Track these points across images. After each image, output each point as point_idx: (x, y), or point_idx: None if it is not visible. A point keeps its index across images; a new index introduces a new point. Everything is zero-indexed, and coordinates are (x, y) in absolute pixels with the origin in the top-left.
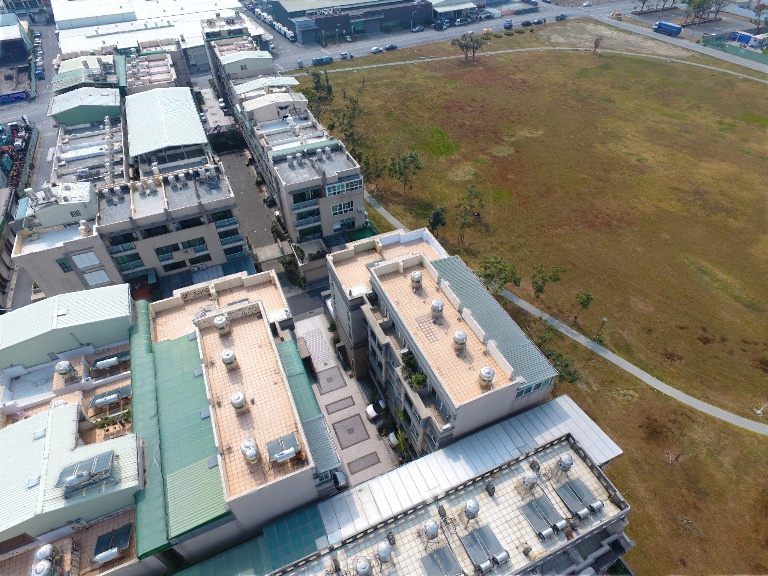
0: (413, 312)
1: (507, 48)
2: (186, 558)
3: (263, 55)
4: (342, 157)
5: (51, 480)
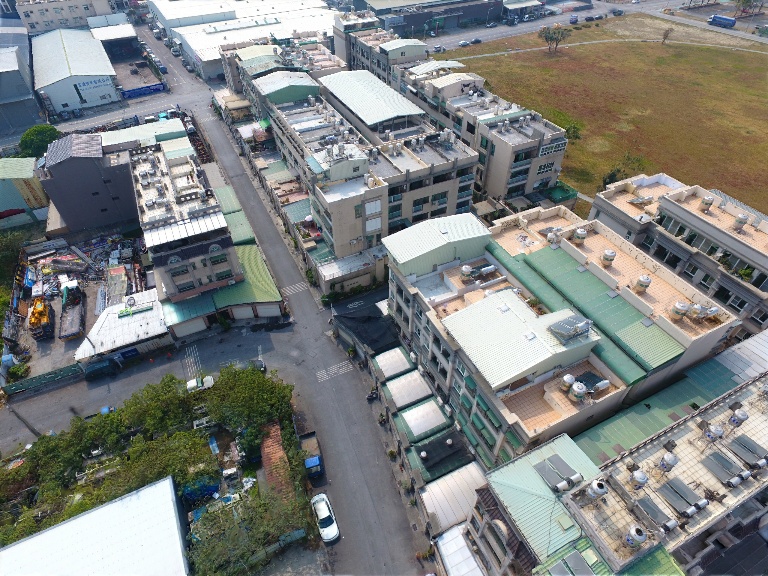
0: None
1: (581, 40)
2: (632, 396)
3: (418, 43)
4: (538, 125)
5: (542, 335)
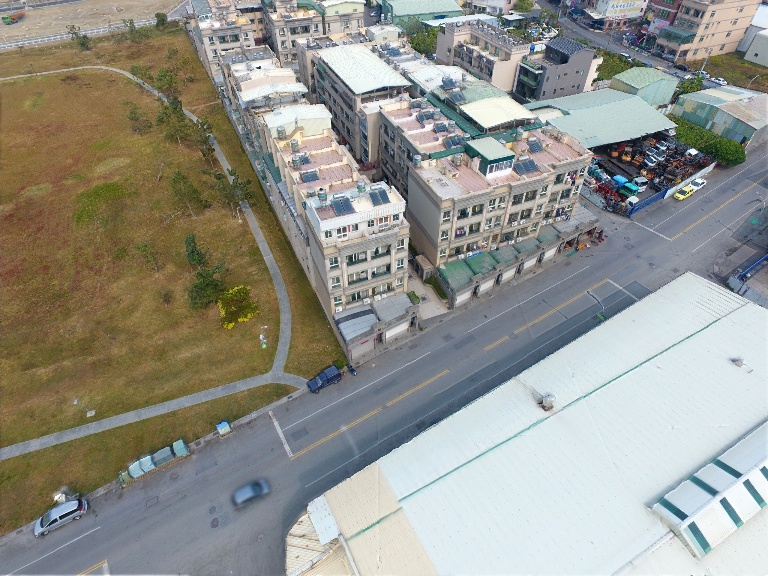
0: (225, 4)
1: None
2: None
3: (274, 116)
4: None
5: None
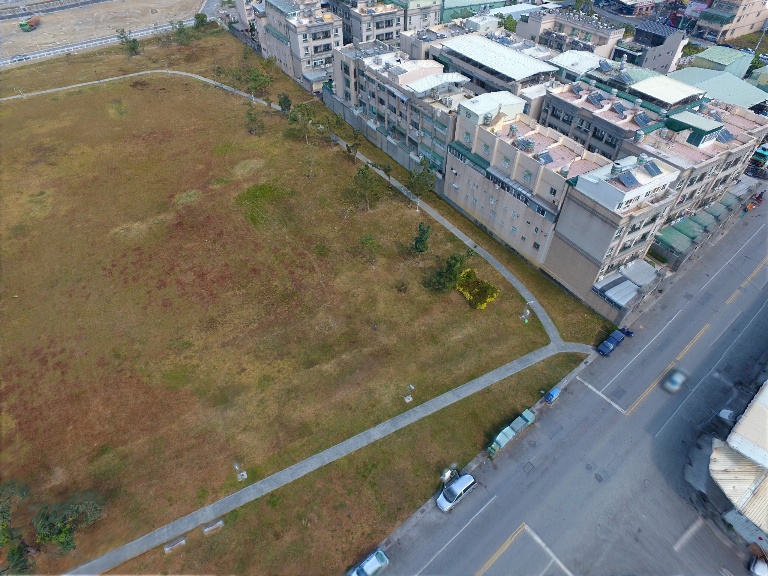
0: None
1: None
2: None
3: (473, 104)
4: None
5: None
